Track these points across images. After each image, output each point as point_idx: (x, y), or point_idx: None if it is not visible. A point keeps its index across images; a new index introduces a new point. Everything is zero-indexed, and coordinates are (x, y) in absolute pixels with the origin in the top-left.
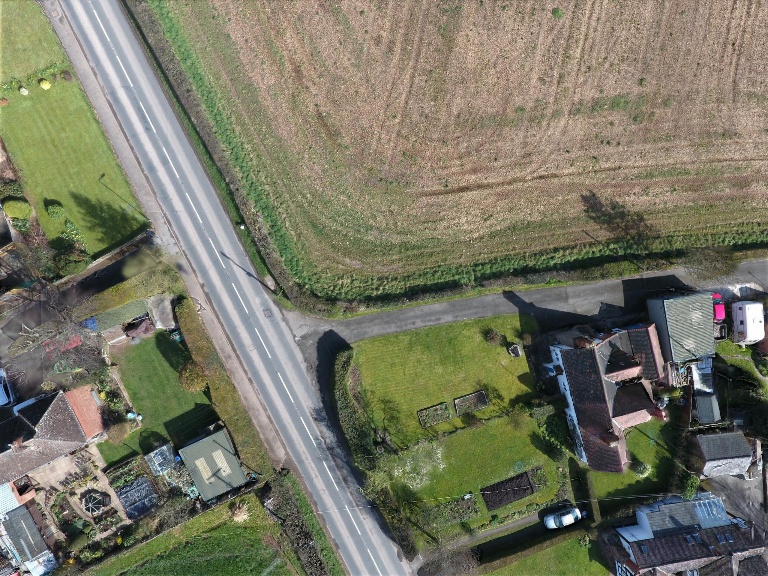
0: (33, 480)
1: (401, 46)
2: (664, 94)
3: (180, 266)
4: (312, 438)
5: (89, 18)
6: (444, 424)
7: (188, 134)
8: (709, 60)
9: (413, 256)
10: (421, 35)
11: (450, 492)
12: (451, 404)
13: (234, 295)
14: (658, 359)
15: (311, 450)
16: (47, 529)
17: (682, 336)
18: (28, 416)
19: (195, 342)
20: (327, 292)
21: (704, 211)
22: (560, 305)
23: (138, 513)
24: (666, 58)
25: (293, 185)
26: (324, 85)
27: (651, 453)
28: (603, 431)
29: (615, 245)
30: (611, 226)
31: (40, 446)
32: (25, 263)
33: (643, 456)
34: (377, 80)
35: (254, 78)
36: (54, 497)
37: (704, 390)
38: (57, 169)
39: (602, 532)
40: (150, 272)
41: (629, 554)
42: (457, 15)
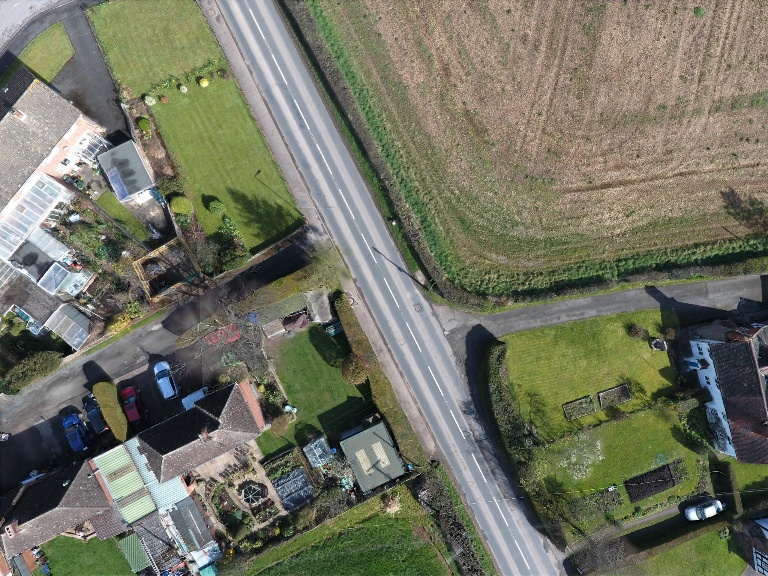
0: (193, 471)
1: (546, 44)
2: None
3: (333, 261)
4: (461, 431)
5: (245, 17)
6: (588, 417)
7: (341, 131)
8: None
9: (558, 252)
10: (566, 34)
11: (595, 484)
12: (595, 397)
13: (386, 290)
14: None
15: (460, 442)
16: (209, 520)
17: None
18: (208, 408)
19: (355, 336)
20: (475, 287)
21: None
22: (700, 300)
23: (294, 504)
24: None
25: (441, 181)
26: (471, 83)
27: None
28: (756, 424)
29: (755, 241)
30: (750, 222)
31: (222, 437)
32: (184, 258)
33: None
34: (523, 78)
35: (404, 76)
36: (214, 488)
37: None
38: (214, 165)
39: None
40: (312, 267)
41: None
42: (601, 14)
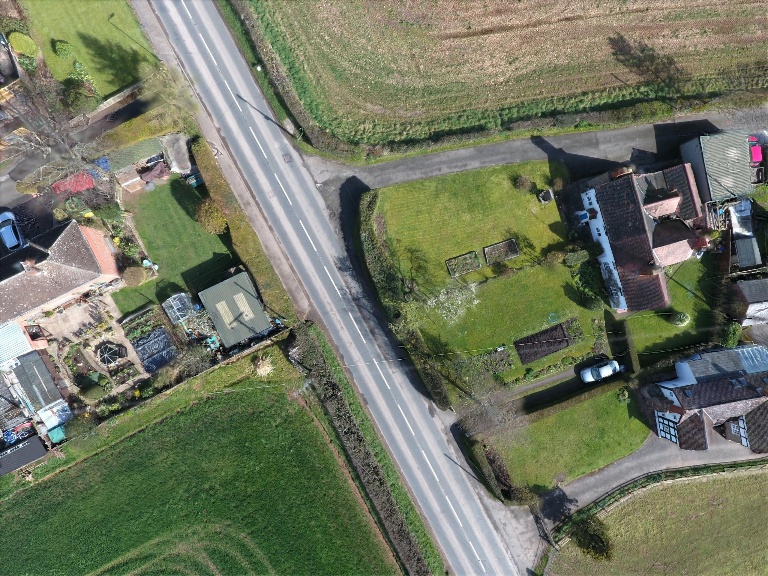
0: (45, 331)
1: None
2: None
3: (195, 109)
4: (337, 288)
5: None
6: (474, 274)
7: None
8: None
9: (437, 100)
10: None
11: (482, 344)
12: (480, 253)
13: (252, 139)
14: (696, 197)
15: (336, 301)
16: (61, 381)
17: None
18: (40, 243)
19: (213, 180)
20: (349, 137)
21: (736, 54)
22: (590, 151)
23: (156, 366)
24: None
25: (310, 27)
26: None
27: (689, 305)
28: (643, 265)
29: (646, 88)
30: (641, 69)
31: (53, 272)
32: (32, 106)
33: (681, 308)
34: None
35: None
36: (67, 348)
37: (743, 234)
38: (64, 9)
39: (641, 387)
40: (164, 106)
41: (672, 401)
42: None
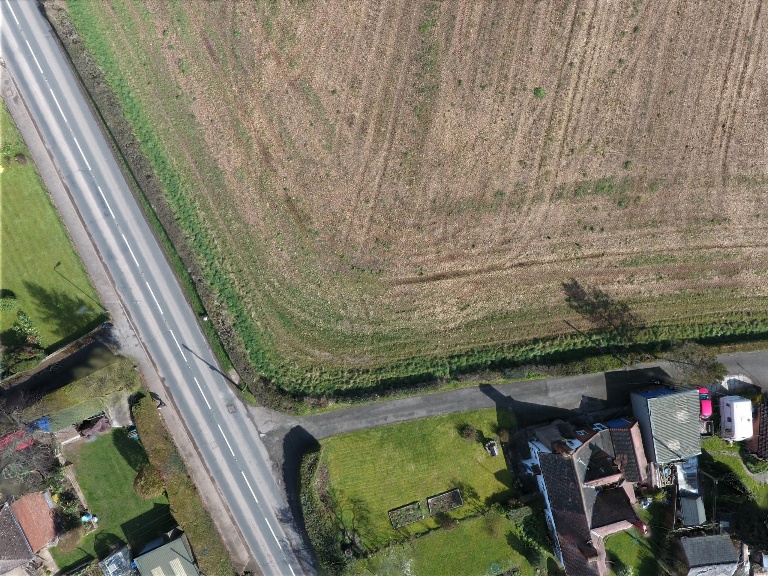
0: None
1: (375, 127)
2: (650, 178)
3: (139, 359)
4: (277, 540)
5: (45, 98)
6: (416, 524)
7: (149, 220)
8: (698, 142)
9: (386, 347)
10: (396, 116)
11: None
12: (424, 503)
13: (196, 390)
14: (641, 461)
15: (276, 553)
16: None
17: (667, 432)
18: None
19: (152, 444)
20: (294, 386)
21: (691, 300)
22: (539, 399)
23: None
24: (653, 140)
25: (260, 273)
26: (293, 168)
27: (633, 553)
28: (581, 541)
29: (598, 336)
30: (594, 316)
31: None
32: None
33: (625, 556)
34: (349, 163)
35: (220, 160)
36: None
37: (689, 490)
38: (10, 257)
39: None
40: (105, 371)
41: None
42: (434, 95)
